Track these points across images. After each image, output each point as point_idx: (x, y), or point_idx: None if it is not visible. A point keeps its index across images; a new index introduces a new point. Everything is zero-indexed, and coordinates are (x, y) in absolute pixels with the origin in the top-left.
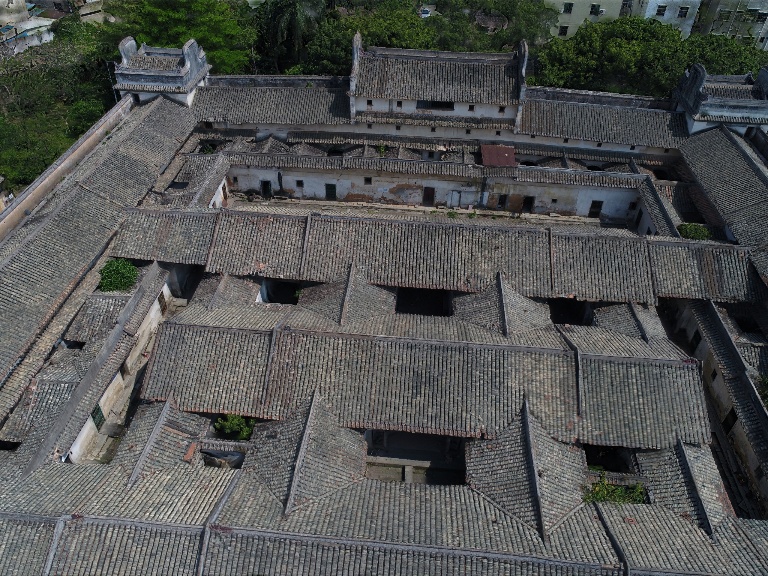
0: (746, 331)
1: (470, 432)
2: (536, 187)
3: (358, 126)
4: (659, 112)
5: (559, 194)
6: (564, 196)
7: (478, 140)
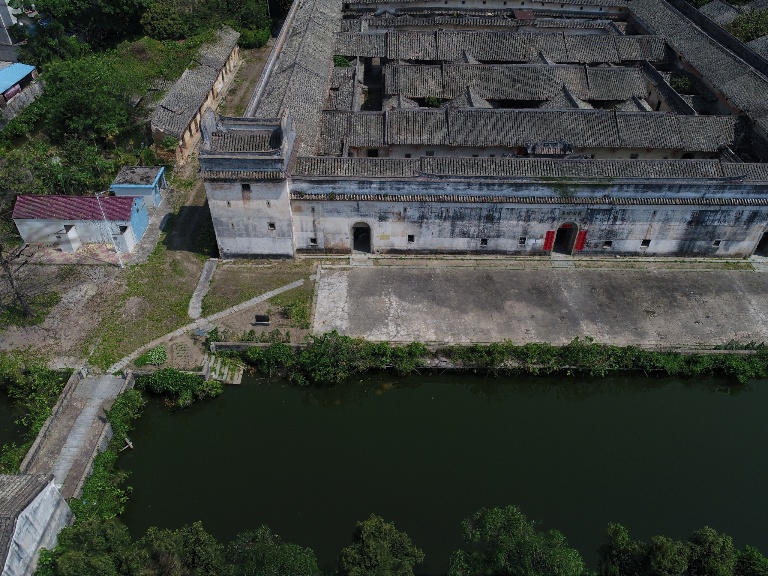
0: None
1: (541, 98)
2: None
3: (439, 3)
4: None
5: None
6: None
7: (511, 8)
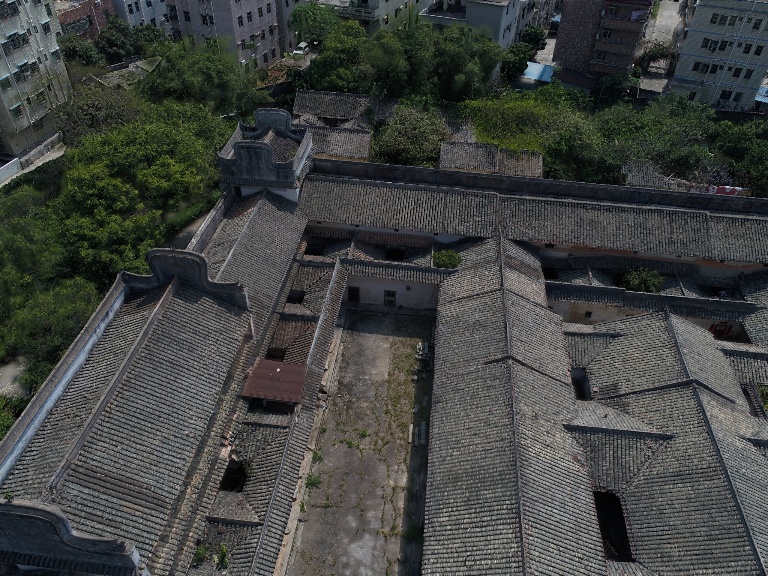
0: (557, 277)
1: None
2: None
3: None
4: (260, 205)
5: None
6: None
7: None
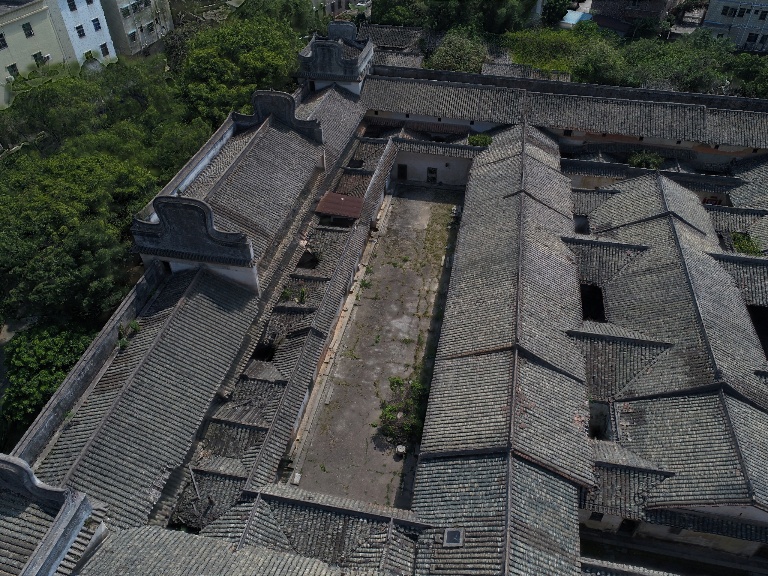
0: None
1: None
2: None
3: None
4: (330, 93)
5: None
6: None
7: None
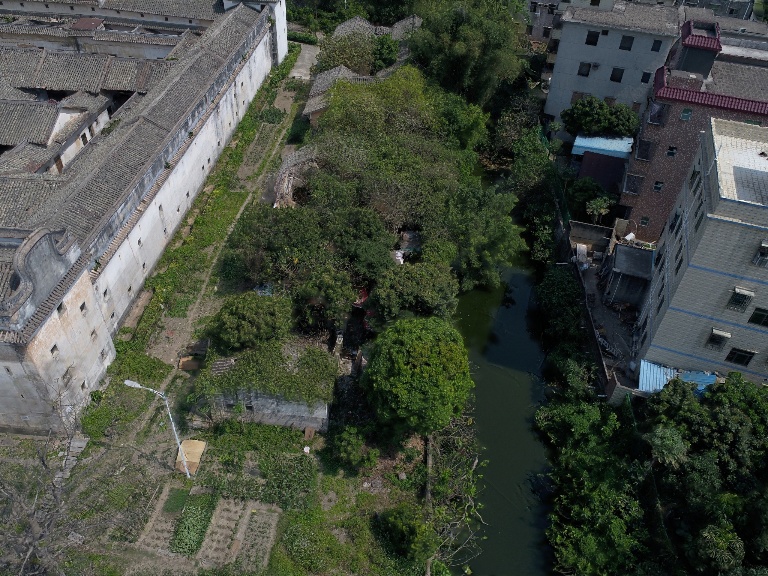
0: None
1: None
2: (114, 47)
3: None
4: None
5: (132, 52)
6: (136, 54)
7: (81, 15)
